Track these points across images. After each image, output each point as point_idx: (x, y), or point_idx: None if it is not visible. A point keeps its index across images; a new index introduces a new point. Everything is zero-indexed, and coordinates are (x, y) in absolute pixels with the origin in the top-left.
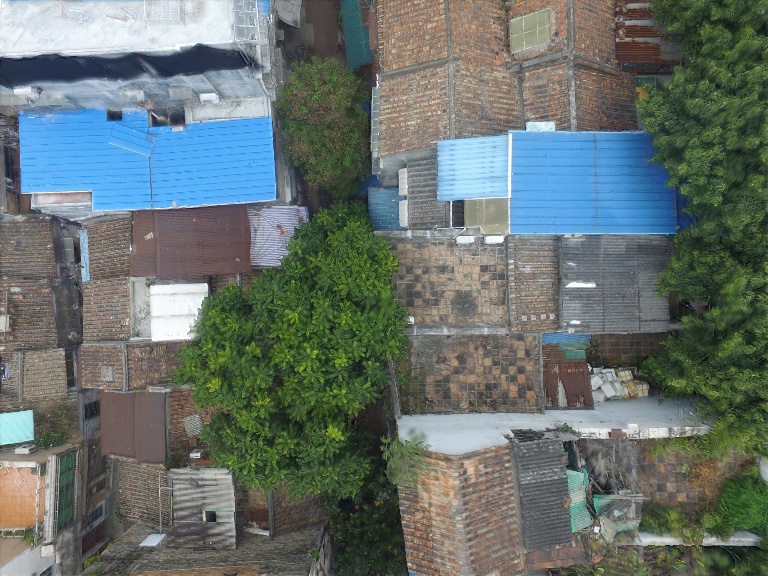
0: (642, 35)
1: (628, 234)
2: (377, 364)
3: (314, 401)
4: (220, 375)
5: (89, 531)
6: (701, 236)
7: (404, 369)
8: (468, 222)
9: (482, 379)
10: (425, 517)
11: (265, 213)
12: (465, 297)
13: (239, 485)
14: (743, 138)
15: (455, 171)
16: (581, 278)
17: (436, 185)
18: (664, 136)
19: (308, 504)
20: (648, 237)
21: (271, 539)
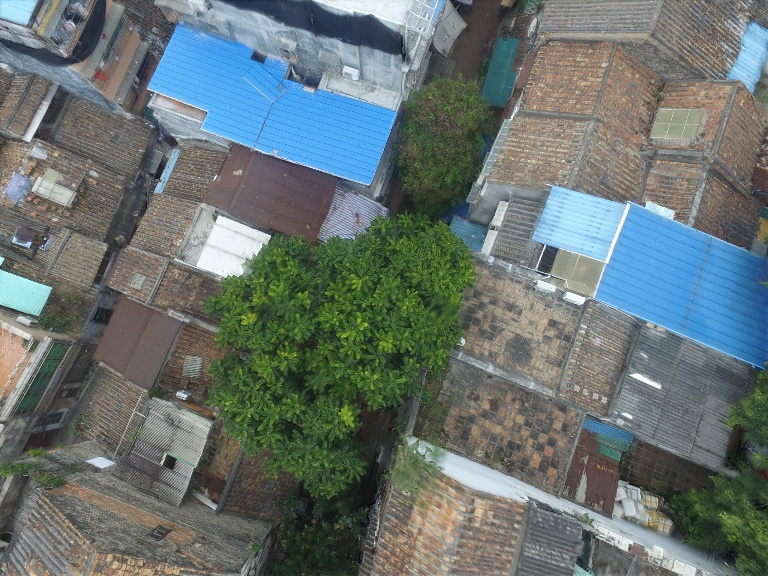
0: None
1: (711, 350)
2: (418, 365)
3: (340, 375)
4: (258, 312)
5: (40, 431)
6: None
7: (432, 390)
8: (555, 271)
9: (508, 434)
10: (408, 543)
11: (350, 197)
12: (523, 343)
13: (209, 445)
14: None
15: (560, 219)
16: (648, 373)
17: (533, 227)
18: None
19: (267, 496)
20: (730, 362)
21: (216, 514)
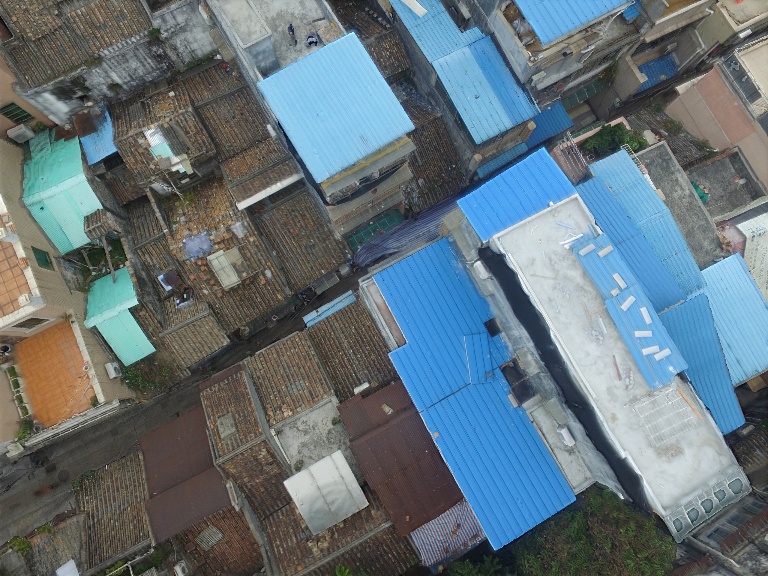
0: None
1: None
2: None
3: None
4: None
5: None
6: None
7: None
8: None
9: None
10: None
11: (467, 508)
12: None
13: None
14: None
15: None
16: None
17: None
18: None
19: None
20: None
21: None
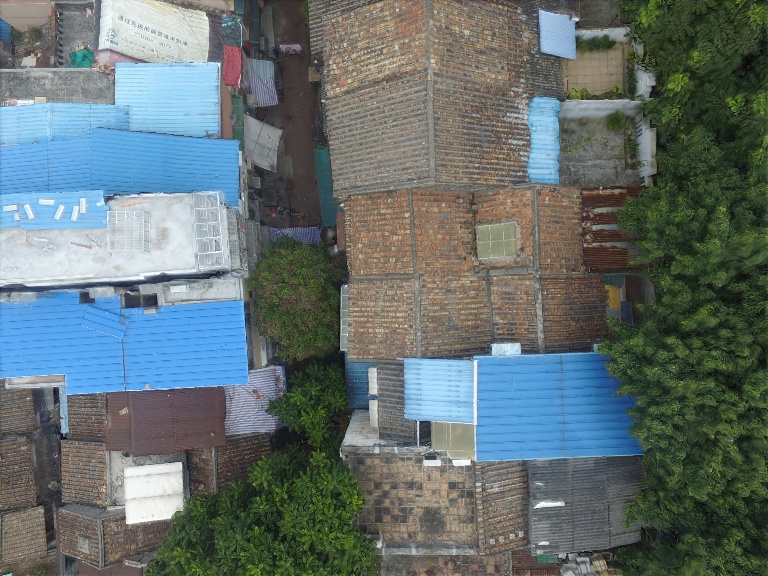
0: (610, 239)
1: None
2: None
3: None
4: None
5: None
6: (666, 478)
7: None
8: (435, 444)
9: None
10: None
11: None
12: (434, 514)
13: None
14: (702, 416)
15: (422, 391)
16: (550, 497)
17: None
18: (626, 386)
19: None
20: None
21: None
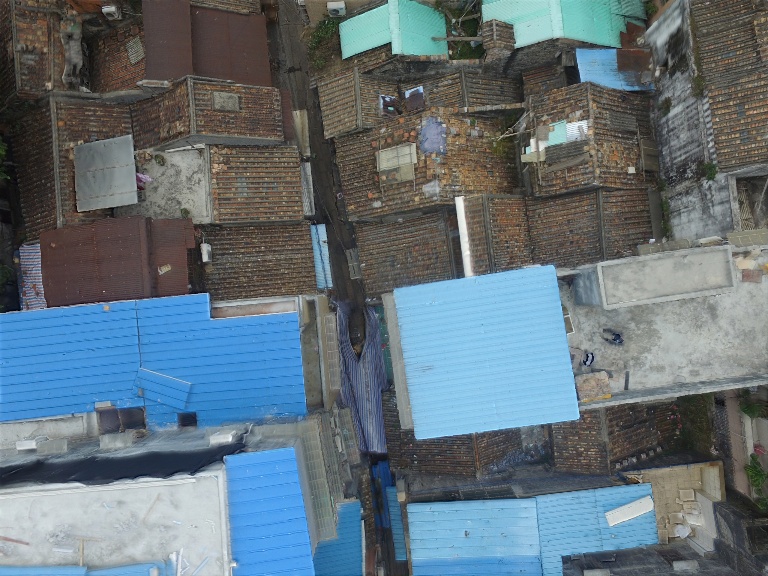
0: None
1: None
2: None
3: None
4: None
5: None
6: None
7: None
8: None
9: None
10: None
11: None
12: None
13: None
14: None
15: None
16: None
17: None
18: None
19: None
20: None
21: None
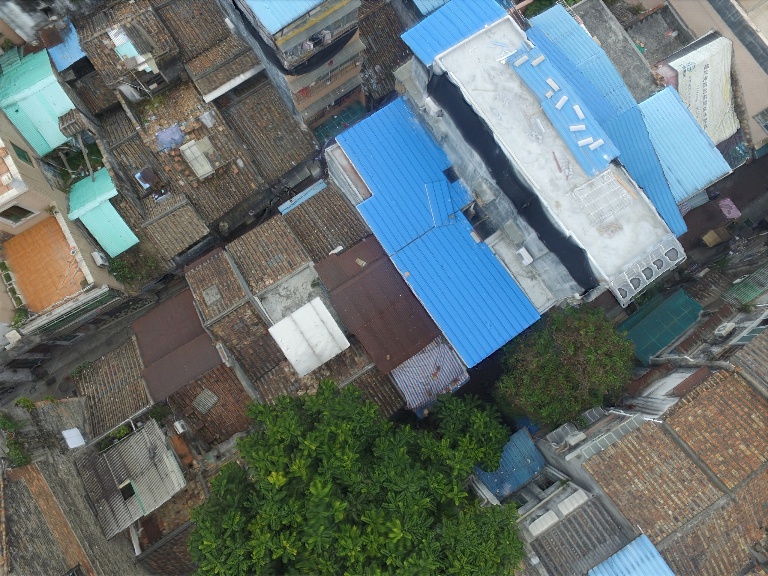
0: None
1: None
2: None
3: None
4: None
5: (49, 344)
6: None
7: None
8: None
9: None
10: None
11: (444, 349)
12: None
13: None
14: None
15: (629, 574)
16: None
17: (595, 548)
18: None
19: (188, 569)
20: None
21: (135, 563)
